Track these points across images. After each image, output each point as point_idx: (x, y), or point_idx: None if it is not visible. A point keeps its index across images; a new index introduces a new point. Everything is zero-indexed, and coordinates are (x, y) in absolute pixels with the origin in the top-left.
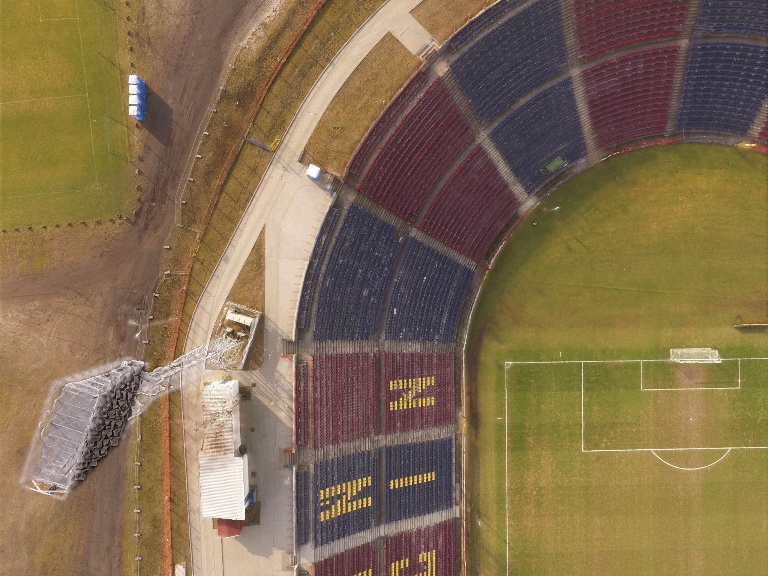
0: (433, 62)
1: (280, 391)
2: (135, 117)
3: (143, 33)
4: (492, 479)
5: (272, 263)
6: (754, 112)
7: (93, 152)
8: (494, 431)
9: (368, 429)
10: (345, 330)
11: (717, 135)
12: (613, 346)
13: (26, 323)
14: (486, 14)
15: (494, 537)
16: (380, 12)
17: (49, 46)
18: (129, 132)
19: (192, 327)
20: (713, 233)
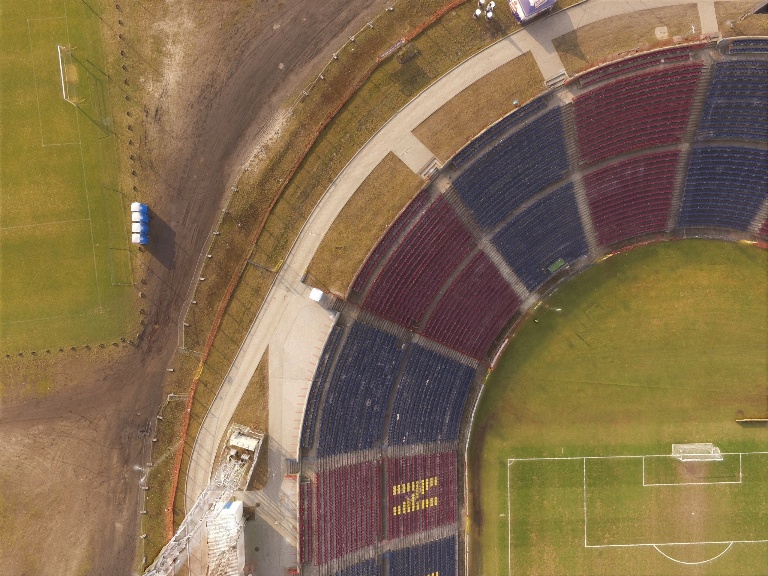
0: (435, 179)
1: (284, 510)
2: (138, 243)
3: (145, 157)
4: (495, 575)
5: (275, 383)
6: (755, 210)
7: (96, 276)
8: (497, 528)
9: (372, 537)
10: (348, 442)
11: (718, 230)
12: (615, 442)
13: (30, 447)
14: (488, 132)
15: None
16: (382, 132)
17: (51, 171)
18: (132, 255)
19: (196, 449)
20: (714, 328)
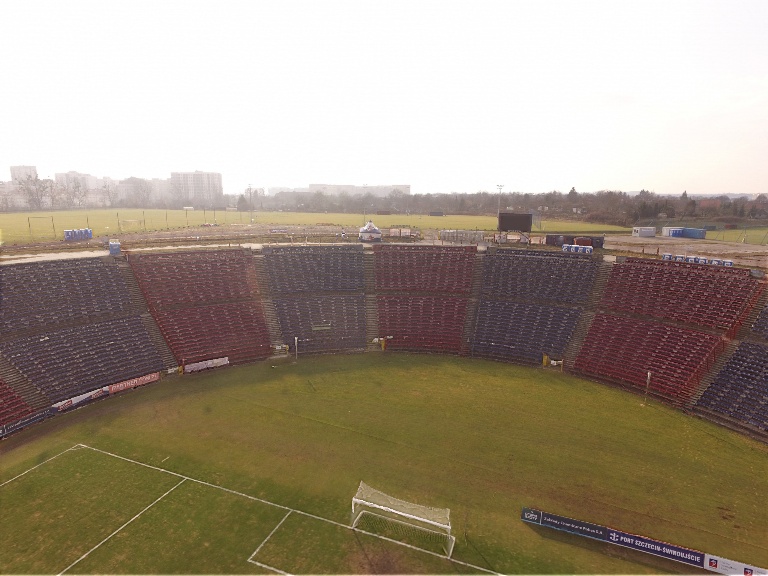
0: None
1: None
2: (66, 235)
3: None
4: None
5: None
6: None
7: None
8: None
9: None
10: None
11: (523, 363)
12: (259, 475)
13: None
14: (307, 248)
15: None
16: None
17: None
18: None
19: None
20: (501, 414)
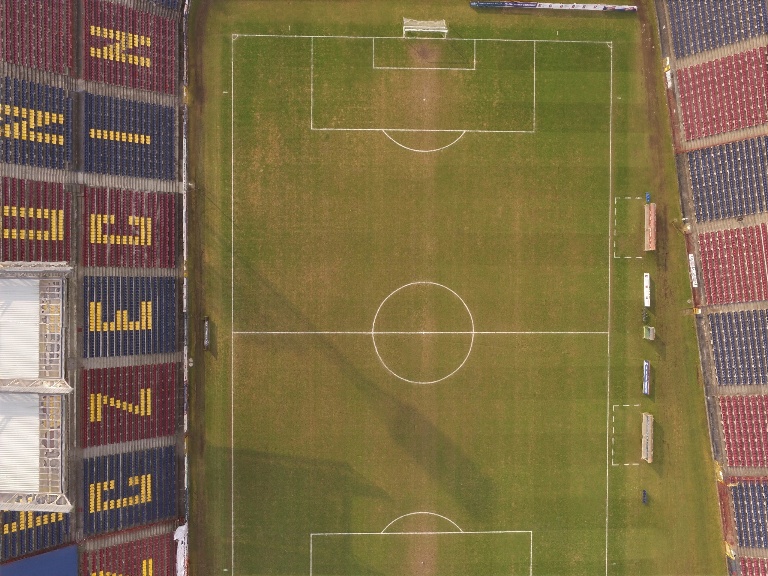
0: None
1: None
2: None
3: None
4: (217, 155)
5: None
6: None
7: None
8: (219, 105)
9: (60, 65)
10: None
11: None
12: (344, 21)
13: None
14: None
15: (219, 215)
16: None
17: None
18: None
19: None
20: None
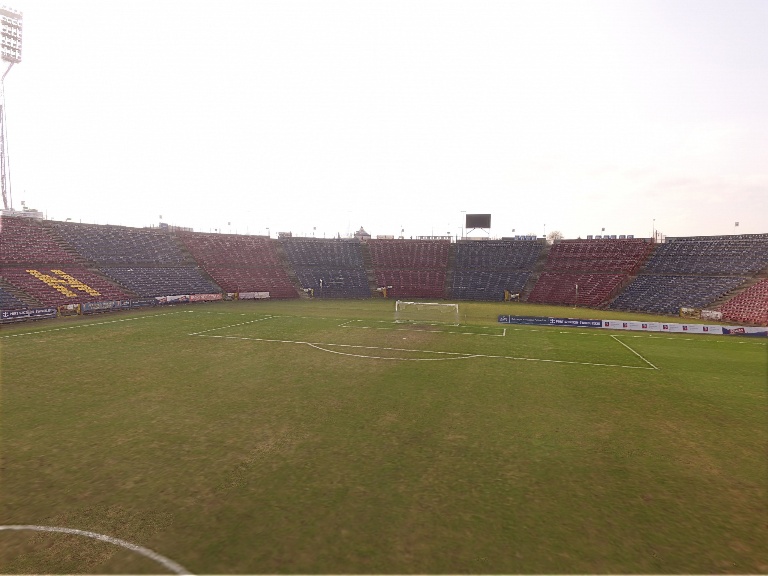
0: None
1: None
2: None
3: None
4: None
5: None
6: None
7: None
8: None
9: None
10: None
11: None
12: None
13: None
14: None
15: None
16: None
17: None
18: None
19: None
20: None
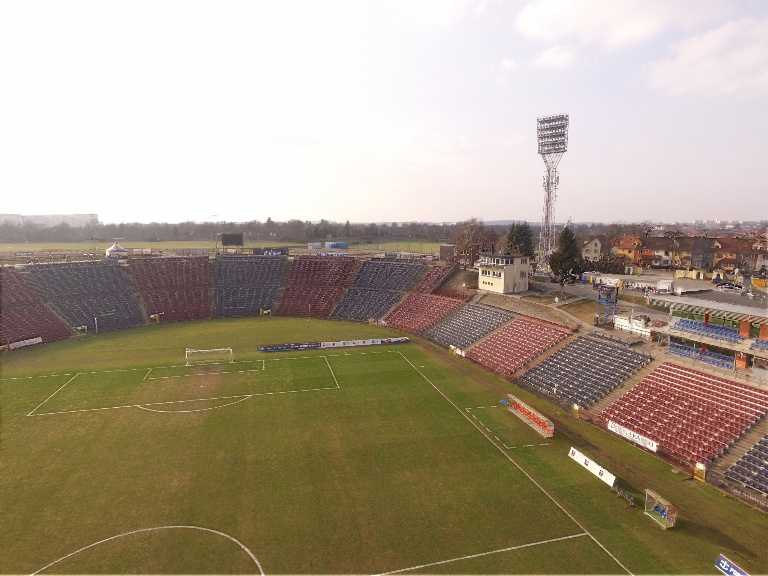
0: None
1: None
2: None
3: None
4: None
5: None
6: None
7: None
8: None
9: None
10: None
11: None
12: None
13: None
14: (68, 264)
15: None
16: None
17: None
18: None
19: None
20: (242, 332)
